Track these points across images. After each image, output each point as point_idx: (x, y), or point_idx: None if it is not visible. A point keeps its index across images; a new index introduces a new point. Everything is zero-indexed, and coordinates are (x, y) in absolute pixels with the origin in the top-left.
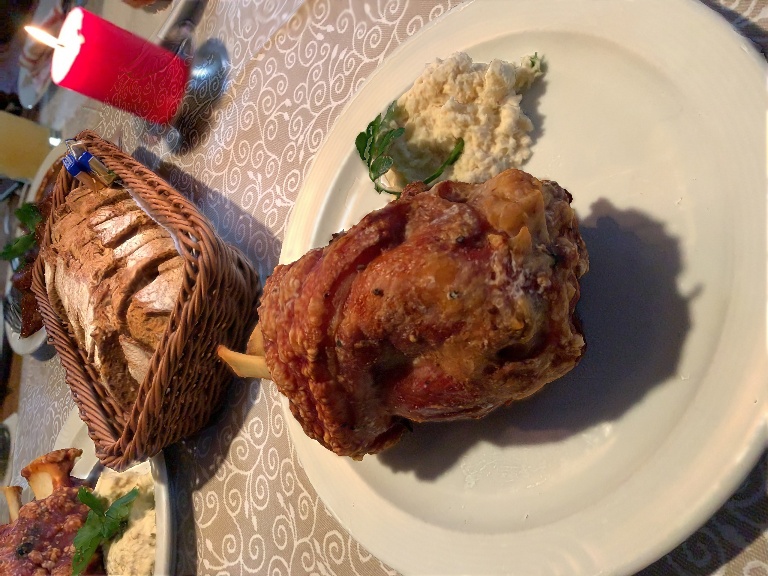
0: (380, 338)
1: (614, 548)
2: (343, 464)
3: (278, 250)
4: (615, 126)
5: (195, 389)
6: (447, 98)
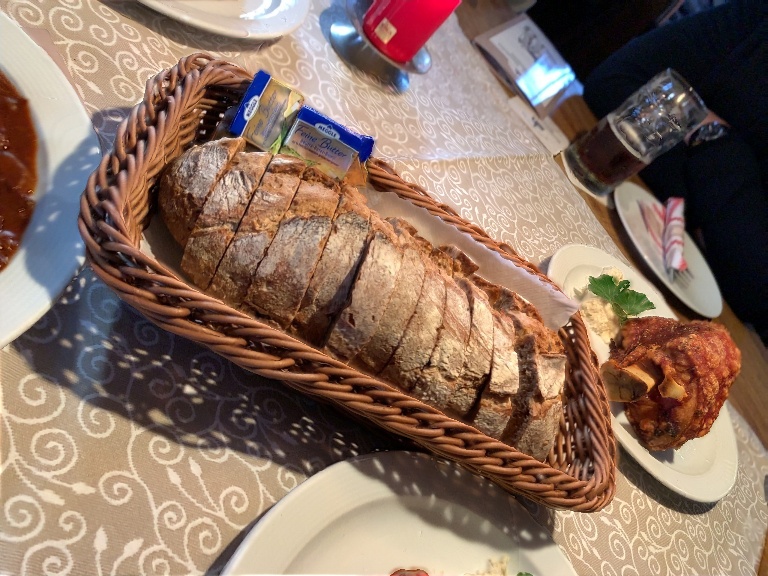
0: None
1: (733, 456)
2: None
3: None
4: None
5: None
6: (616, 284)
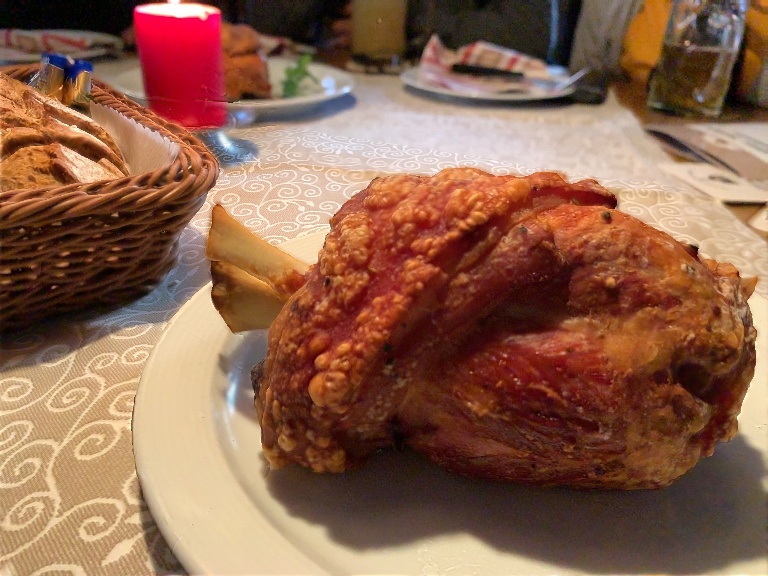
0: (568, 260)
1: None
2: (217, 458)
3: None
4: None
5: (0, 277)
6: None
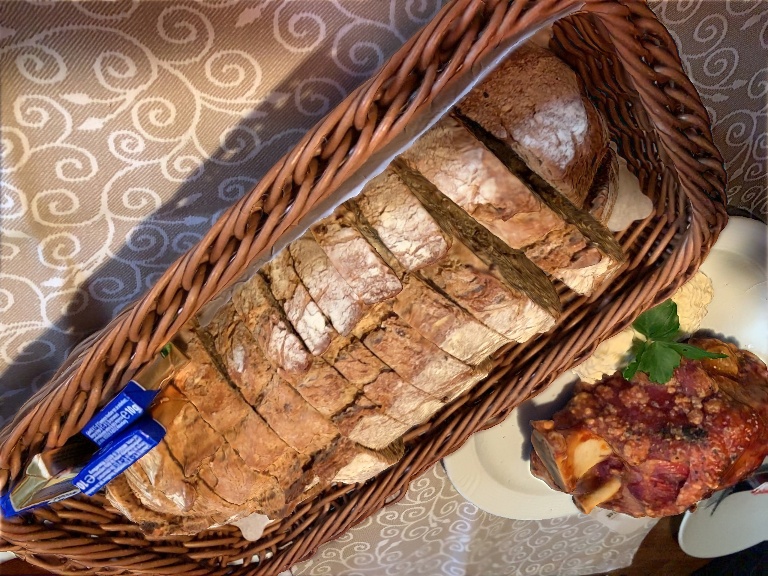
0: None
1: None
2: None
3: None
4: None
5: None
6: None
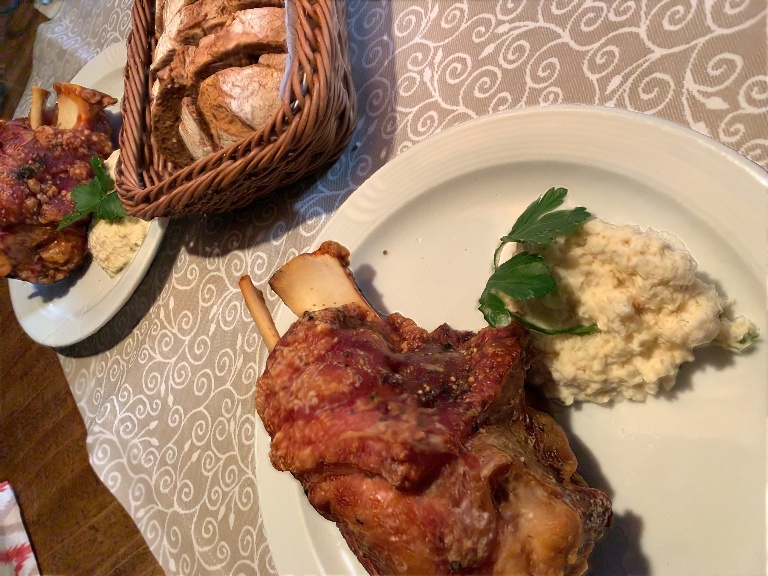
0: None
1: None
2: None
3: (388, 128)
4: (723, 491)
5: None
6: (631, 281)
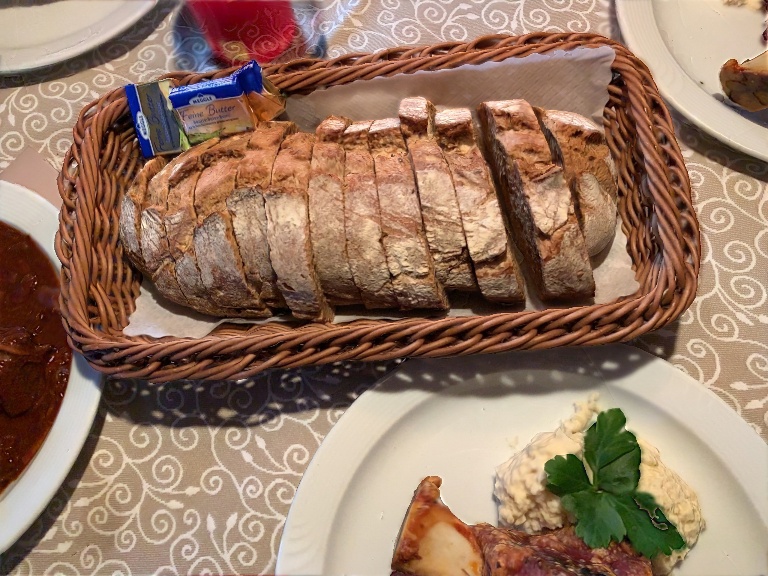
0: None
1: None
2: None
3: None
4: None
5: None
6: None
